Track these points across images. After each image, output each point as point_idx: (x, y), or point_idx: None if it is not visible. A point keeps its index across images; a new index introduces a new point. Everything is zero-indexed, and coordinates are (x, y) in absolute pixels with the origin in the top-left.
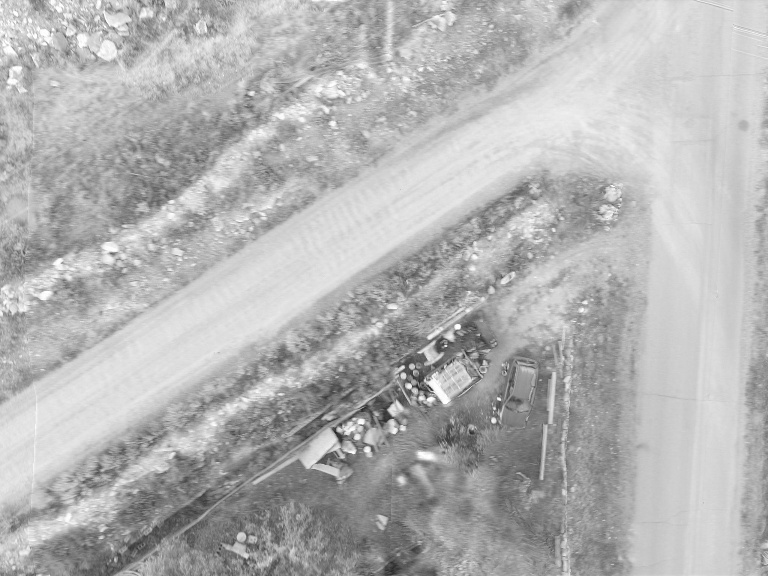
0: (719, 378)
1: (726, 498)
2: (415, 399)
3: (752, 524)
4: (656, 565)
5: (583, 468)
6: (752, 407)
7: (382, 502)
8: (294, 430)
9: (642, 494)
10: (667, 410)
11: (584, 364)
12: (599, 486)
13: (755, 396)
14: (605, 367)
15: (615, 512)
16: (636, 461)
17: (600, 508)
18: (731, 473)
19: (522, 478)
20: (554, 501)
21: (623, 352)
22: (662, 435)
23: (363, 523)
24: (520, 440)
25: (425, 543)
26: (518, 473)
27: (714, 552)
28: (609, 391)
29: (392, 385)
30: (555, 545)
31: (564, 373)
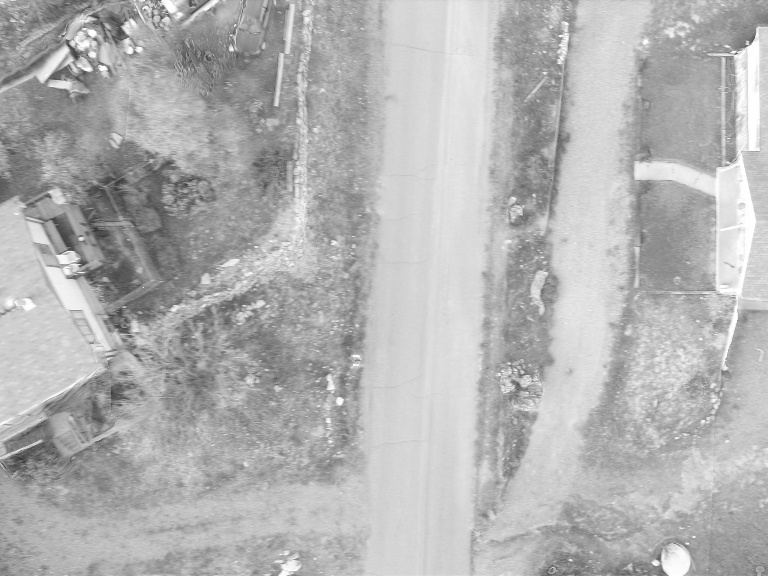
0: (467, 32)
1: (474, 154)
2: (151, 20)
3: (500, 180)
4: (404, 219)
5: (327, 111)
6: (500, 62)
7: (117, 121)
8: (27, 40)
9: (390, 146)
10: (415, 62)
11: (329, 7)
12: (346, 135)
13: (503, 51)
14: (353, 16)
15: (363, 163)
16: (384, 113)
17: (347, 157)
18: (479, 128)
19: (253, 100)
20: (288, 129)
21: (371, 1)
22: (410, 87)
23: (97, 141)
24: (257, 70)
25: (156, 161)
26: (252, 98)
27: (462, 208)
28: (357, 40)
29: (128, 5)
30: (287, 170)
31: (303, 7)
